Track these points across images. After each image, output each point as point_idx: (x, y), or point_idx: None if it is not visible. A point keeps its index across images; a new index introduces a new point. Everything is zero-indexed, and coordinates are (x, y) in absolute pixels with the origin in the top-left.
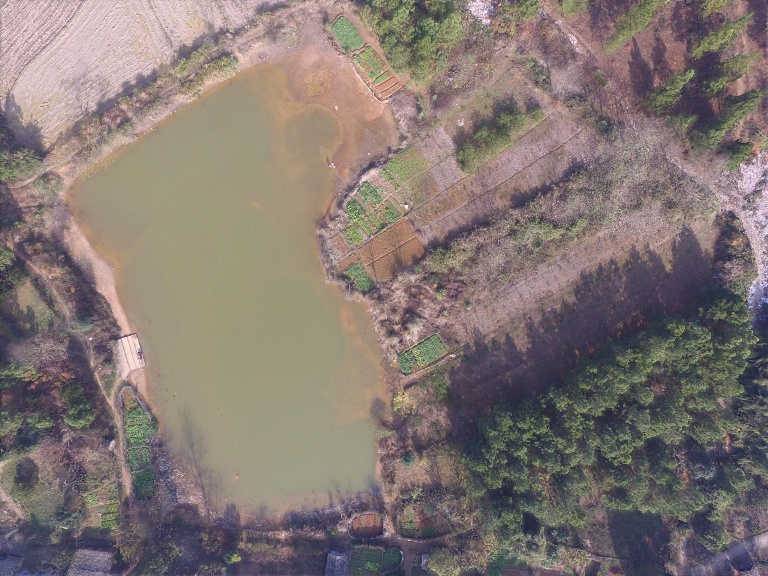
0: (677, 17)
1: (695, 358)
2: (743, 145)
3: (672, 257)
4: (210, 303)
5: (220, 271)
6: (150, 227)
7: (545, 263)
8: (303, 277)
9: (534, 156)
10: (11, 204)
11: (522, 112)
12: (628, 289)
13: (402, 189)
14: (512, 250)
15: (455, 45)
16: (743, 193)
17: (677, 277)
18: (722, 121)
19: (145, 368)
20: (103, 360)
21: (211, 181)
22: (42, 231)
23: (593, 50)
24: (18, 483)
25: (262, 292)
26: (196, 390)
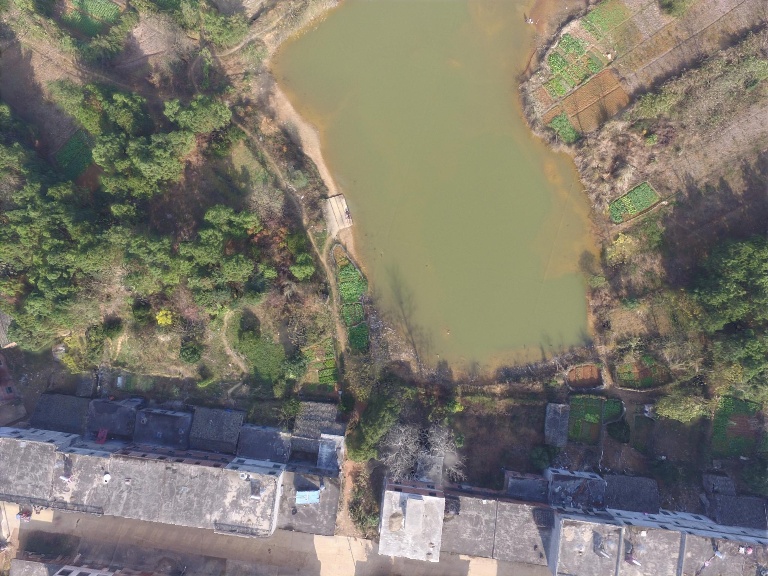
0: None
1: None
2: None
3: None
4: (413, 162)
5: (422, 130)
6: (351, 90)
7: (758, 104)
8: (505, 133)
9: None
10: (218, 73)
11: None
12: None
13: (604, 39)
14: (722, 93)
15: None
16: None
17: None
18: None
19: (352, 228)
20: (317, 216)
21: (409, 43)
22: (249, 97)
23: None
24: (248, 331)
25: (465, 149)
26: (403, 248)
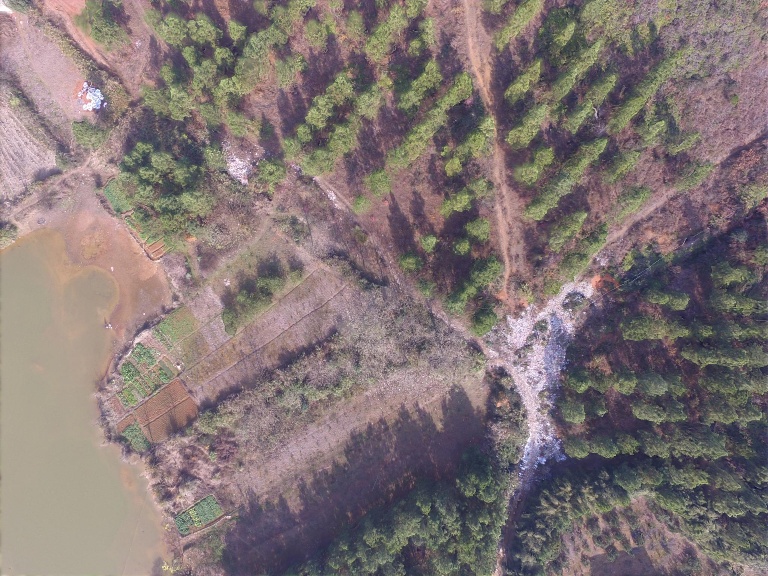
0: (432, 170)
1: (440, 540)
2: (482, 316)
3: (442, 416)
4: None
5: (8, 433)
6: None
7: (315, 423)
8: (85, 438)
9: (299, 314)
10: None
11: (285, 270)
12: (399, 449)
13: (174, 350)
14: (282, 410)
15: (206, 212)
16: (514, 348)
17: (449, 436)
18: (463, 289)
19: None
20: None
21: None
22: None
23: (351, 206)
24: None
25: (47, 453)
26: None
